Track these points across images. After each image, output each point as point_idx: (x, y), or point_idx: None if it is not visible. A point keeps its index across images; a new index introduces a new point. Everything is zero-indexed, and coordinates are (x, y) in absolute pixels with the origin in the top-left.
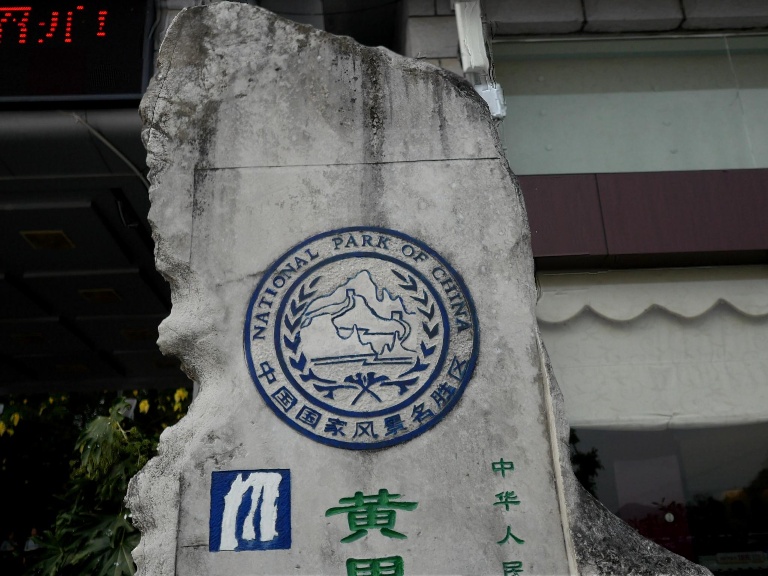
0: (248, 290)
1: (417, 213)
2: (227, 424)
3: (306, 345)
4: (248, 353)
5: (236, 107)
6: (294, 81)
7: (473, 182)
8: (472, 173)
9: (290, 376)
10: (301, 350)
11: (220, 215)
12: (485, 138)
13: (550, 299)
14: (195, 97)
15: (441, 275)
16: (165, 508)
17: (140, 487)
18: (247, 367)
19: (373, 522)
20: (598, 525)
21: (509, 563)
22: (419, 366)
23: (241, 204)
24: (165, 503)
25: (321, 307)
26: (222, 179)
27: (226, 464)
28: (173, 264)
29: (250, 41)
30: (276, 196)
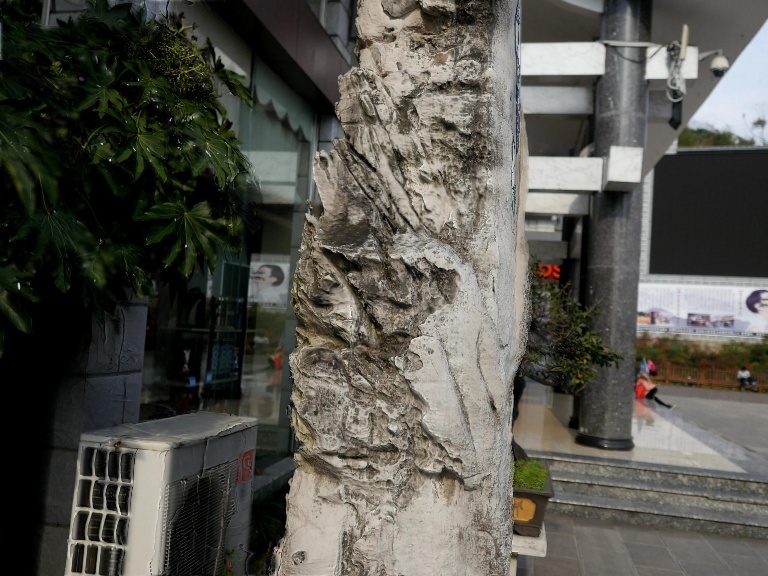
0: None
1: None
2: None
3: None
4: None
5: None
6: None
7: None
8: None
9: None
10: None
11: None
12: None
13: (195, 1)
14: None
15: None
16: (508, 151)
17: None
18: None
19: None
20: None
21: None
22: None
23: None
24: (508, 146)
25: None
26: None
27: None
28: None
29: None
30: None
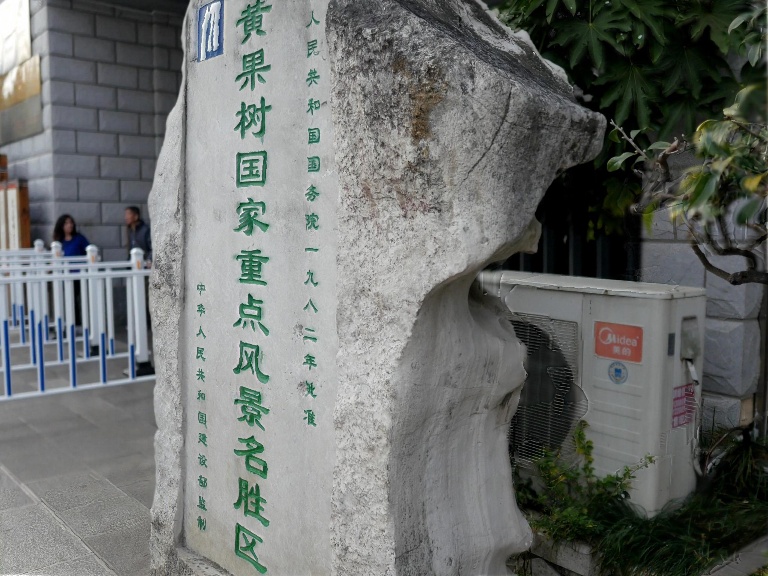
0: None
1: None
2: None
3: None
4: None
5: None
6: None
7: None
8: None
9: None
10: None
11: None
12: None
13: None
14: None
15: None
16: None
17: None
18: None
19: (254, 26)
20: None
21: (310, 42)
22: None
23: None
24: None
25: None
26: None
27: None
28: None
29: None
30: None
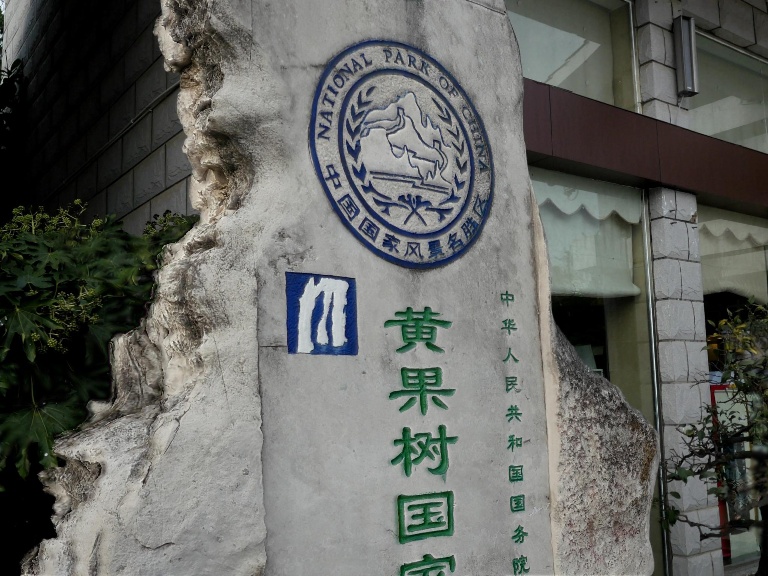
0: (312, 82)
1: (450, 47)
2: (298, 224)
3: (366, 156)
4: (314, 151)
5: None
6: None
7: (490, 32)
8: (489, 23)
9: (354, 185)
10: (361, 160)
11: None
12: None
13: None
14: None
15: (468, 115)
16: (241, 304)
17: (204, 279)
18: (313, 166)
19: (420, 336)
20: (568, 351)
21: (510, 378)
22: (454, 198)
23: None
24: (241, 299)
25: (377, 119)
26: None
27: (298, 265)
28: (233, 27)
29: None
30: None
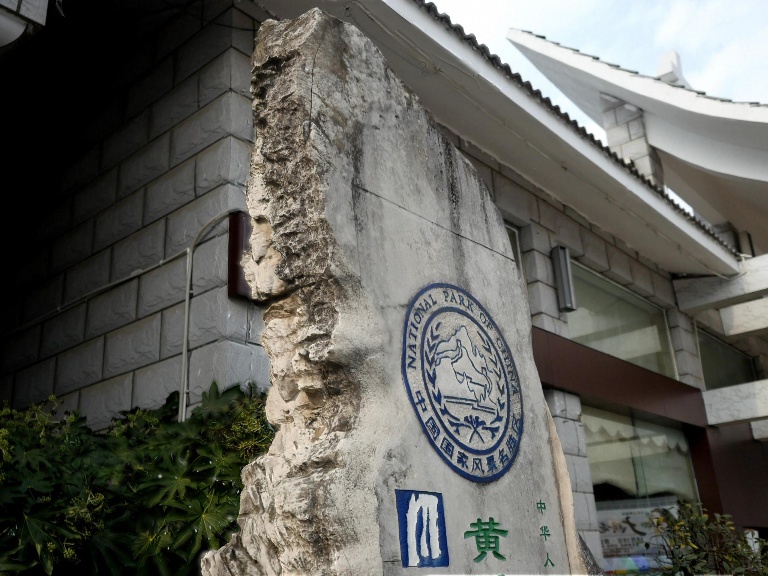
0: (401, 319)
1: (484, 288)
2: (401, 445)
3: (440, 382)
4: (406, 379)
5: (374, 137)
6: (407, 134)
7: (506, 275)
8: (505, 267)
9: (435, 408)
10: (437, 386)
11: (375, 238)
12: (507, 241)
13: None
14: (345, 110)
15: (500, 345)
16: (367, 522)
17: (335, 498)
18: (406, 393)
19: (488, 545)
20: None
21: None
22: (499, 417)
23: (387, 234)
24: (367, 517)
25: (445, 350)
26: (372, 203)
27: (403, 483)
28: (347, 274)
29: (375, 77)
30: (406, 236)
